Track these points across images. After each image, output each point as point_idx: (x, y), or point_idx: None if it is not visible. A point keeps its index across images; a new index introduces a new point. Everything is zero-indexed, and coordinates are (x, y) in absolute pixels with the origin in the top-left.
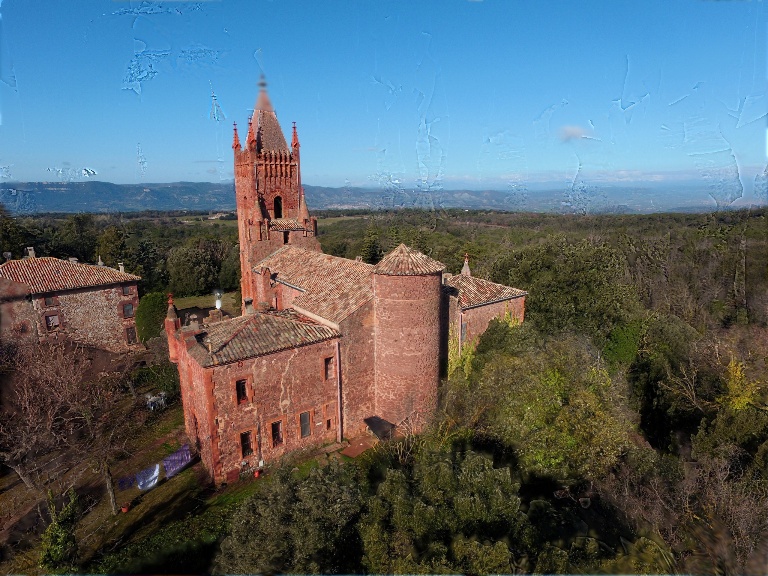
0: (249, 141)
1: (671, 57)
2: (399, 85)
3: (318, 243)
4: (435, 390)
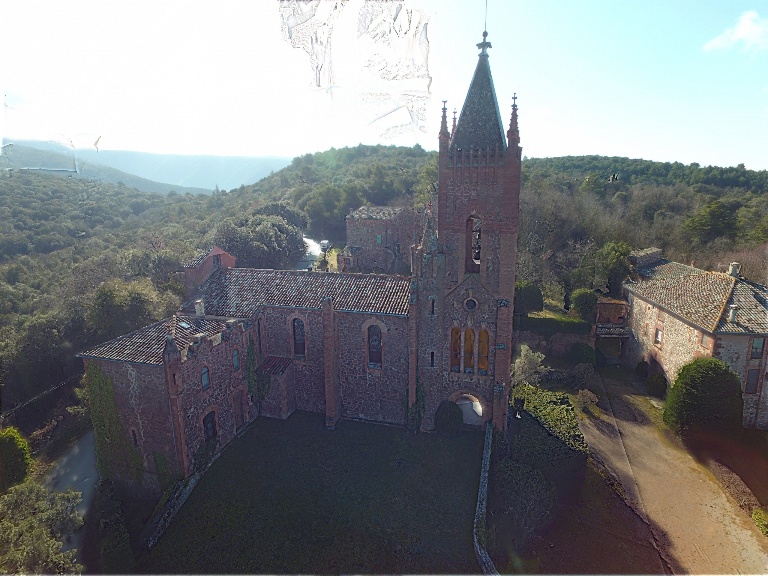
0: None
1: None
2: None
3: (411, 285)
4: None
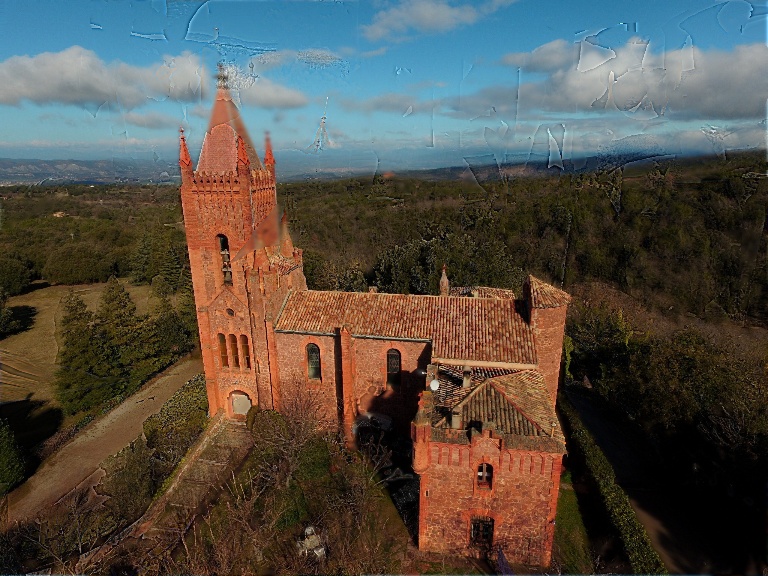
0: (244, 161)
1: (466, 82)
2: (170, 57)
3: (304, 278)
4: None
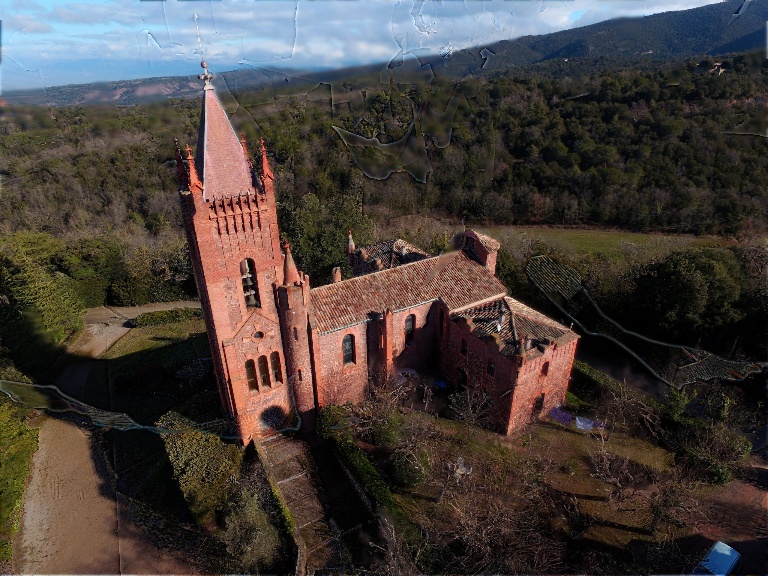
0: None
1: (247, 28)
2: None
3: None
4: None
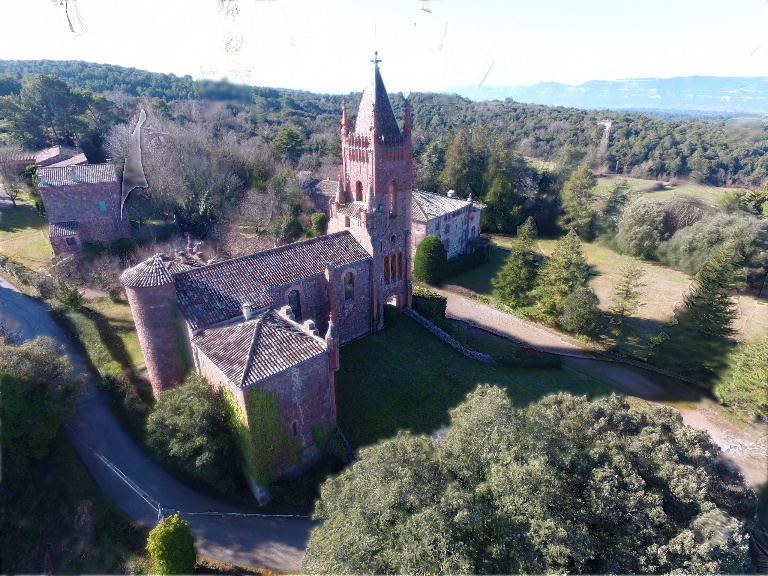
0: None
1: None
2: None
3: (369, 236)
4: (155, 377)
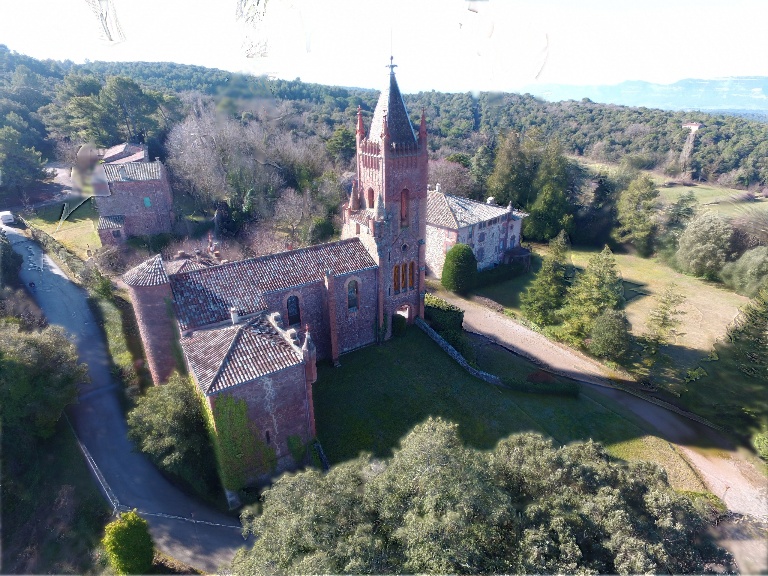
0: None
1: None
2: None
3: (376, 245)
4: (154, 372)
